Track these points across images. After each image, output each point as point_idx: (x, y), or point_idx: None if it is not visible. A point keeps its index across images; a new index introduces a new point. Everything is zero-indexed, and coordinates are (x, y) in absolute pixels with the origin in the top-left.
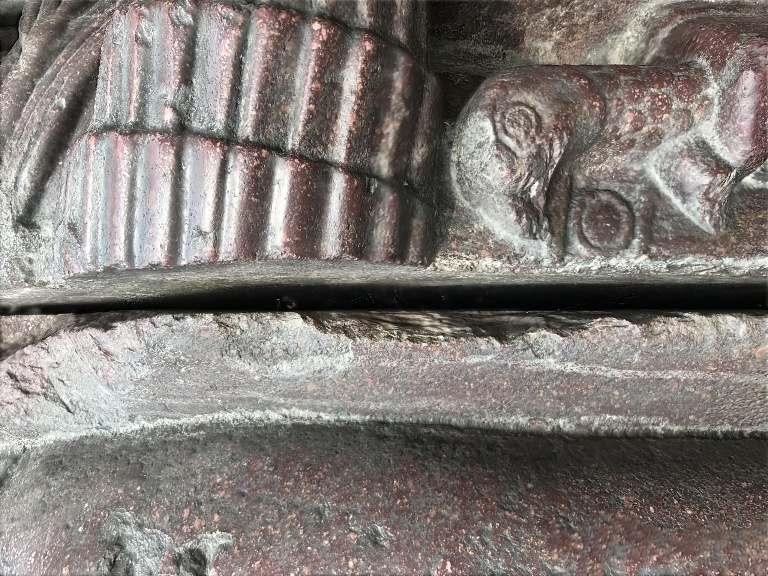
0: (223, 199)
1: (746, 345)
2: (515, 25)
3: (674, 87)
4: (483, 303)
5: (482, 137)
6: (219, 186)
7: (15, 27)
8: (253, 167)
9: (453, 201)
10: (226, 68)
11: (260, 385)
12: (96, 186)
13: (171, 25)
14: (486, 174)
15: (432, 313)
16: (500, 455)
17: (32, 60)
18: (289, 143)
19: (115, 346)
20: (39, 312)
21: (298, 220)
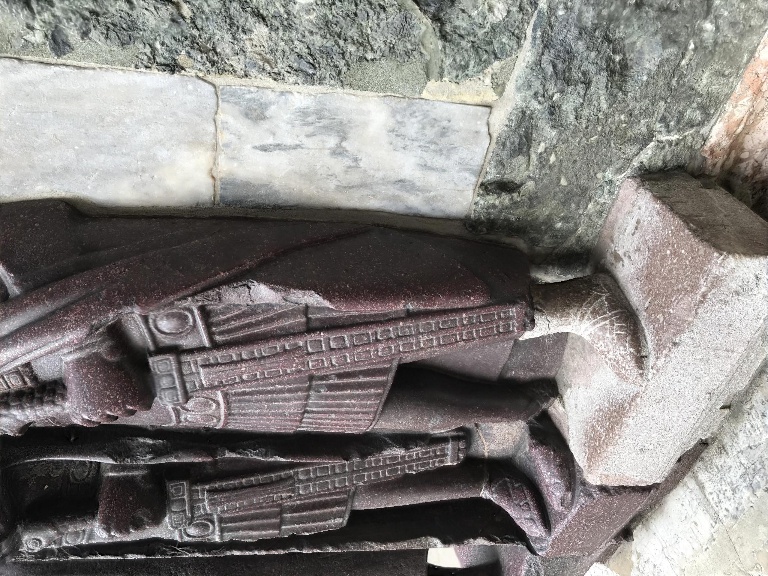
0: None
1: (115, 558)
2: None
3: (87, 526)
4: None
5: None
6: None
7: None
8: None
9: None
10: None
11: None
12: None
13: None
14: None
15: None
16: (49, 570)
17: None
18: None
19: None
20: None
21: None
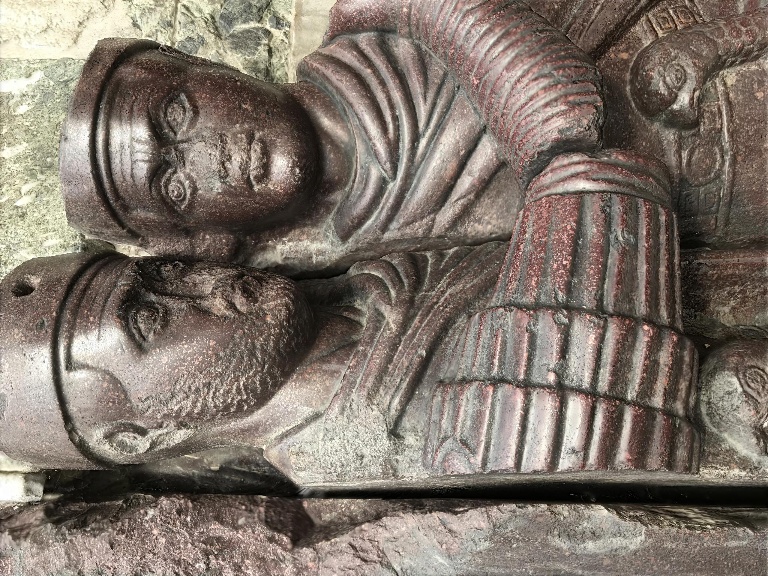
0: (592, 431)
1: None
2: (704, 297)
3: None
4: (713, 501)
5: (730, 388)
6: (590, 423)
7: (311, 280)
8: (612, 411)
9: (704, 428)
10: (593, 351)
11: (568, 559)
12: (492, 417)
13: (555, 325)
14: (737, 413)
15: (691, 508)
16: None
17: (400, 324)
18: (628, 396)
19: (459, 526)
20: (350, 497)
21: (637, 445)
